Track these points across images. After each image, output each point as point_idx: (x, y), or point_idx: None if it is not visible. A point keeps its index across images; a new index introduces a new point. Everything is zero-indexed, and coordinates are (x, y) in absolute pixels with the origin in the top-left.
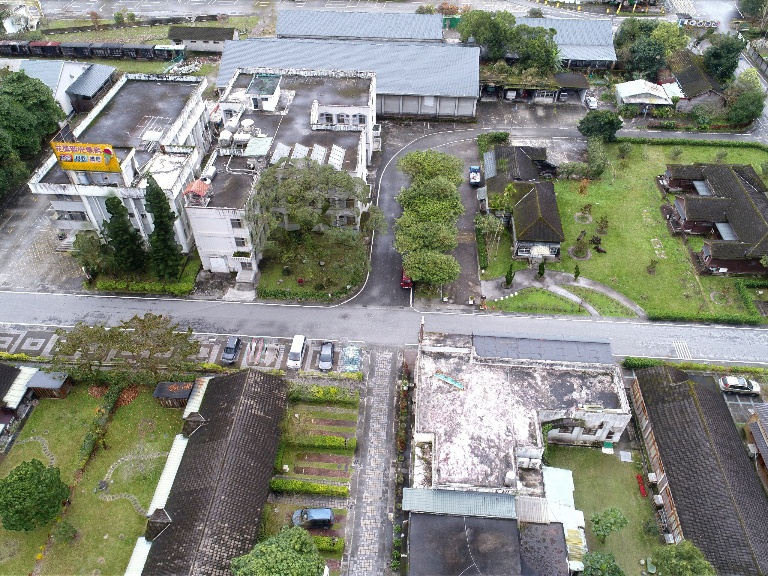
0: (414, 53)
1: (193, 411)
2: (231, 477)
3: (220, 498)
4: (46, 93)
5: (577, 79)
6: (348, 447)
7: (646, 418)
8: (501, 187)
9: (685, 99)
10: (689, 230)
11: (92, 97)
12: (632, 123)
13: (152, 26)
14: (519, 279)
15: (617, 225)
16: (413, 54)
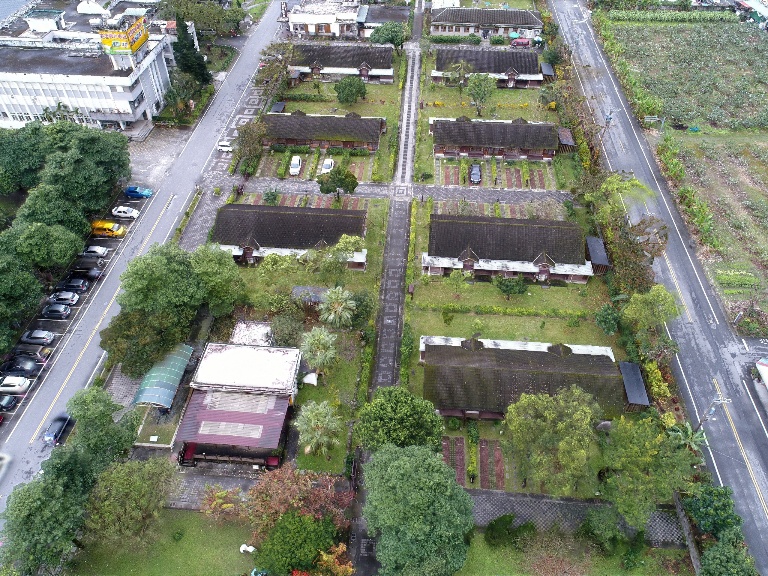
0: None
1: (308, 69)
2: None
3: None
4: None
5: None
6: None
7: None
8: None
9: None
10: None
11: None
12: None
13: None
14: None
15: None
16: None
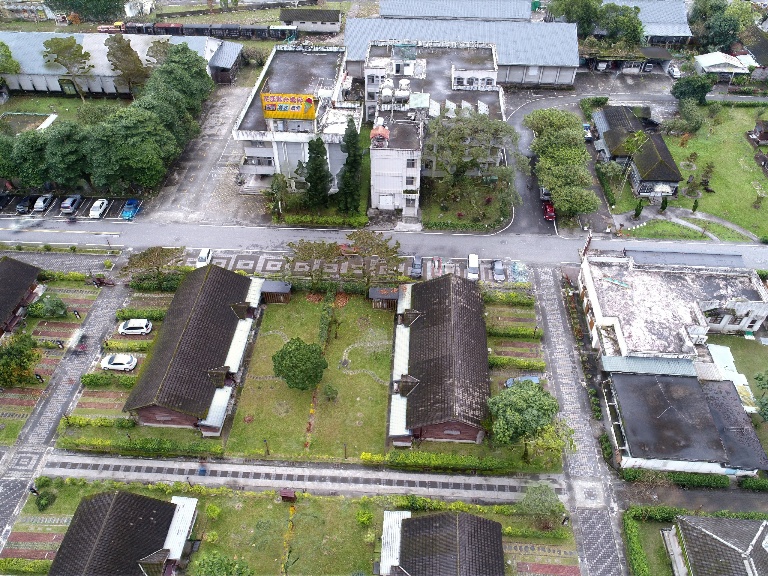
0: (518, 28)
1: (406, 308)
2: (461, 349)
3: (458, 362)
4: (203, 63)
5: (661, 52)
6: (536, 336)
7: None
8: (619, 138)
9: (760, 68)
10: None
11: (230, 69)
12: (714, 89)
13: (255, 10)
14: (644, 213)
15: (719, 171)
16: (517, 29)
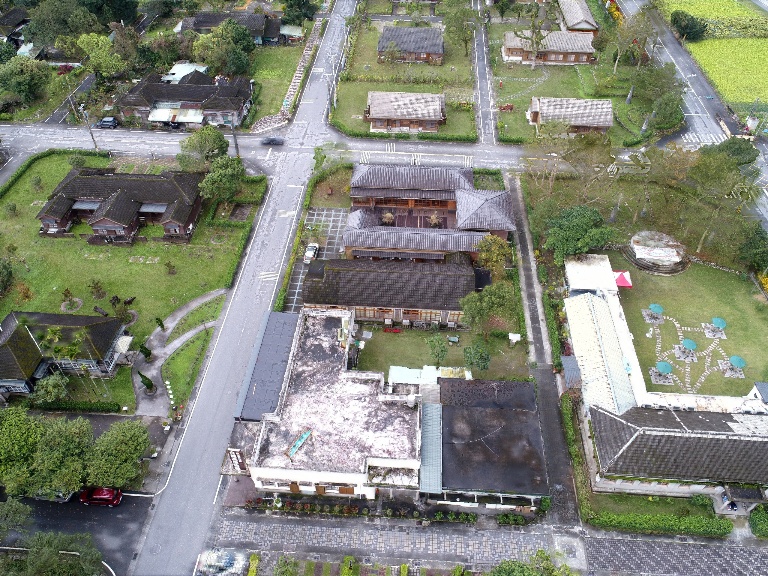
0: None
1: None
2: None
3: None
4: None
5: None
6: None
7: (343, 309)
8: (1, 359)
9: None
10: (132, 232)
11: None
12: None
13: None
14: None
15: (97, 281)
16: None
